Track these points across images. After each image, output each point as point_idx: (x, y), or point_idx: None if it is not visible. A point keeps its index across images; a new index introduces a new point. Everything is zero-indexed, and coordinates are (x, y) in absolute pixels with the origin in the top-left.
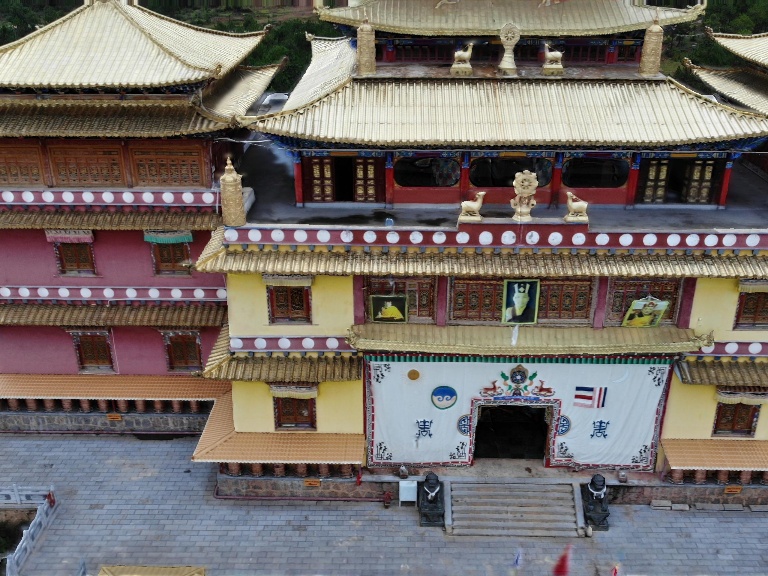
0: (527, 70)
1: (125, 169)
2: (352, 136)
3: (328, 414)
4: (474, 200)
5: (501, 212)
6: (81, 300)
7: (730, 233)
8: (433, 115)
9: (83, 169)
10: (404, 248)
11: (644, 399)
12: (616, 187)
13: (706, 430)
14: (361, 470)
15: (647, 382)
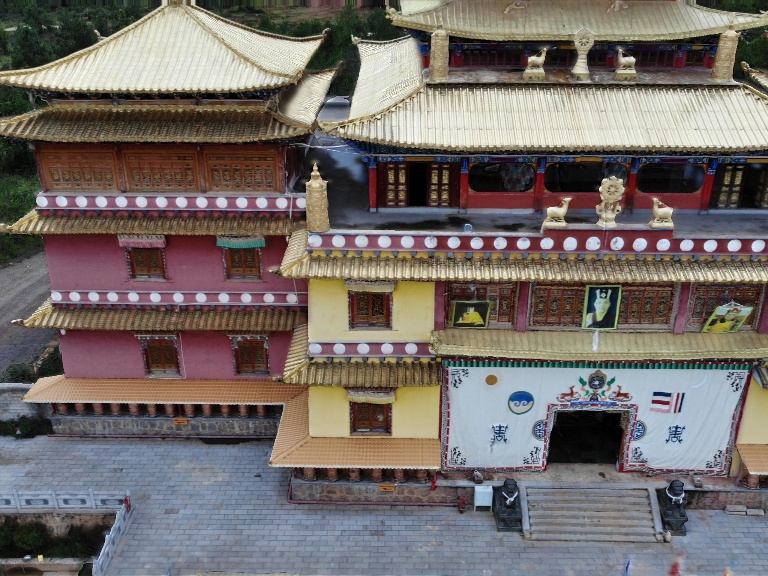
0: (598, 75)
1: (199, 174)
2: (431, 142)
3: (404, 419)
4: (559, 206)
5: (576, 217)
6: (151, 305)
7: None
8: (510, 120)
9: (157, 174)
10: (488, 254)
11: (721, 404)
12: (691, 192)
13: None
14: (435, 475)
15: (725, 387)
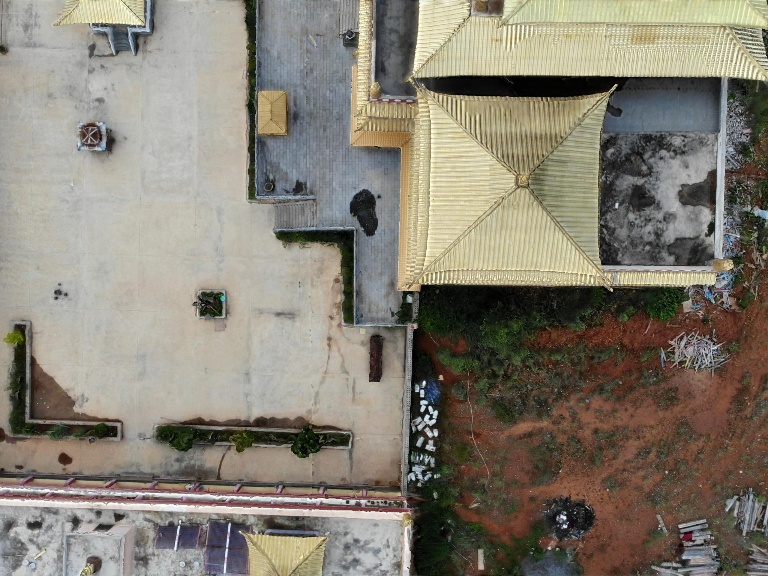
0: None
1: None
2: None
3: None
4: None
5: None
6: None
7: (372, 47)
8: None
9: None
10: None
11: None
12: None
13: None
14: None
15: None
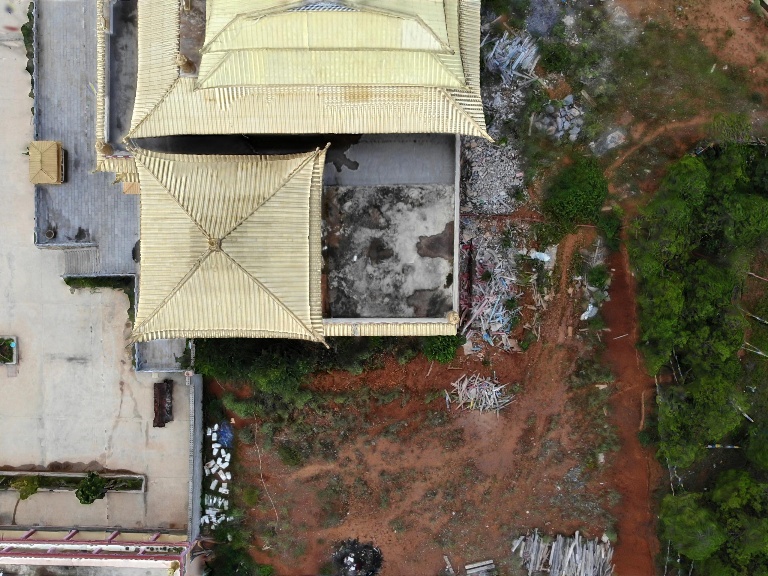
0: None
1: None
2: None
3: None
4: None
5: None
6: None
7: (105, 104)
8: None
9: None
10: None
11: None
12: None
13: None
14: None
15: None
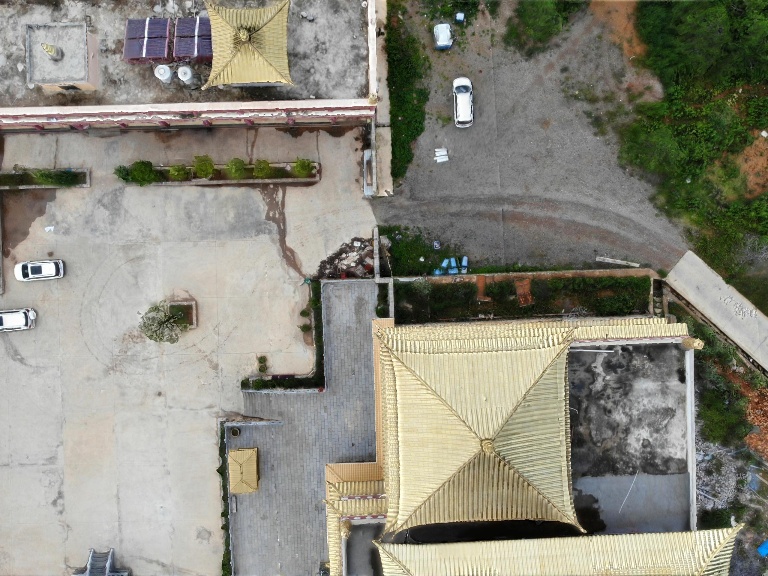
0: None
1: None
2: None
3: None
4: None
5: None
6: None
7: None
8: None
9: None
10: None
11: None
12: None
13: None
14: None
15: None
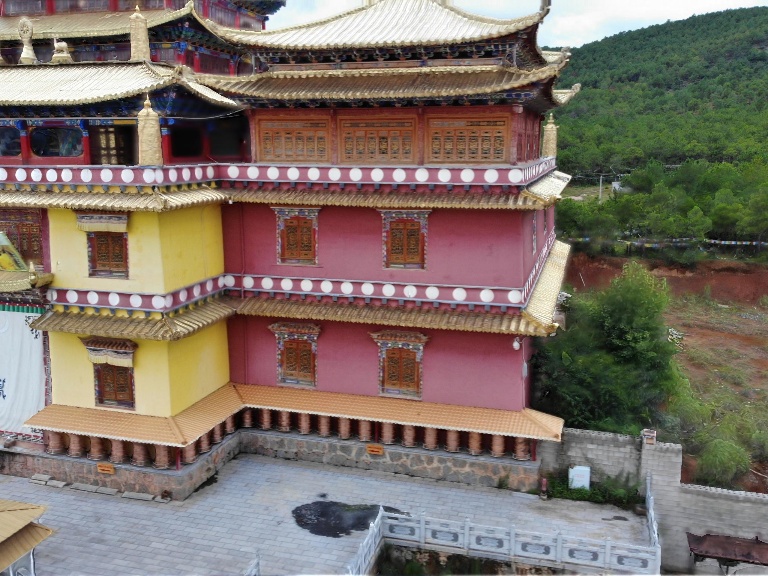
0: None
1: None
2: None
3: None
4: None
5: None
6: None
7: (66, 167)
8: None
9: None
10: None
11: (28, 354)
12: (76, 156)
13: (90, 397)
14: None
15: (26, 334)
